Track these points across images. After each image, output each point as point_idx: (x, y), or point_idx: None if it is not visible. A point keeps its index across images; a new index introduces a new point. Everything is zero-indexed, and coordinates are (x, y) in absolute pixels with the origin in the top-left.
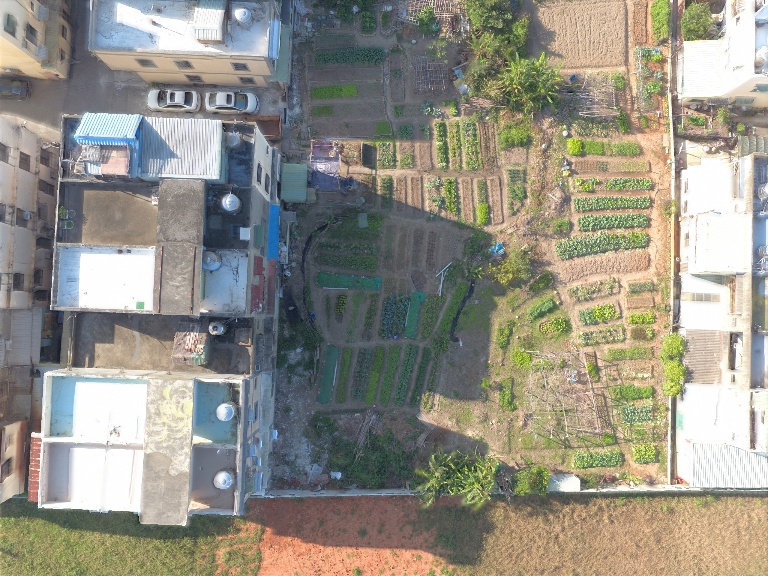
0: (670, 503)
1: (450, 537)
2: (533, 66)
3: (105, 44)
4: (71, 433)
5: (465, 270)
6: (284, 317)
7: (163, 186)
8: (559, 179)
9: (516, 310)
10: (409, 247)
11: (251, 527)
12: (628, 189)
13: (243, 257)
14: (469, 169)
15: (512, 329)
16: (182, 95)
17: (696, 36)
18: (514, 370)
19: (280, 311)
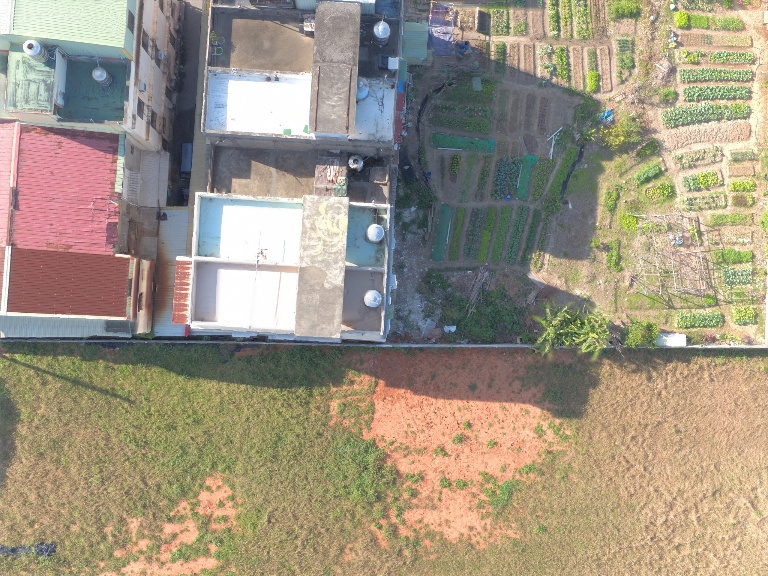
0: (767, 363)
1: (558, 392)
2: None
3: None
4: (218, 255)
5: (575, 135)
6: (399, 176)
7: (320, 8)
8: (666, 50)
9: (623, 175)
10: (521, 111)
11: (365, 379)
12: (731, 62)
13: (388, 89)
14: (580, 38)
15: (619, 193)
16: None
17: None
18: (621, 232)
19: None
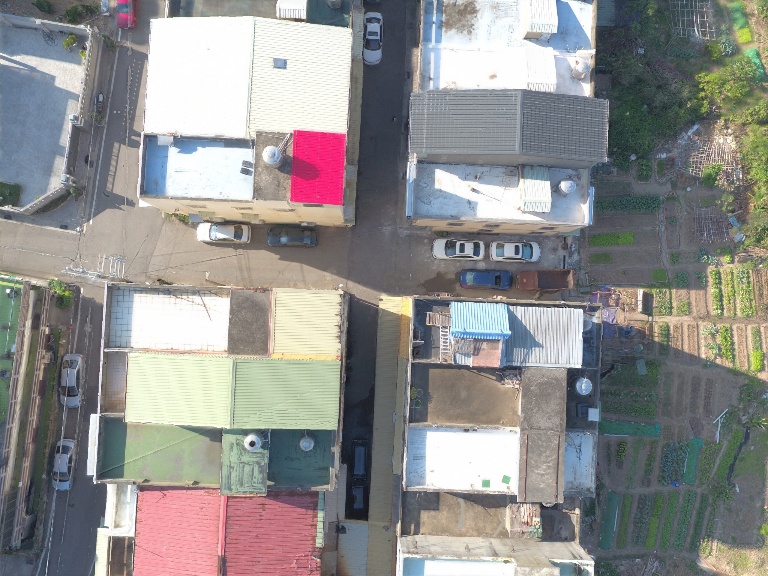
0: None
1: None
2: None
3: (424, 210)
4: None
5: (741, 417)
6: None
7: (526, 374)
8: None
9: None
10: (687, 394)
11: None
12: None
13: (586, 435)
14: (743, 316)
15: None
16: (471, 246)
17: None
18: None
19: None
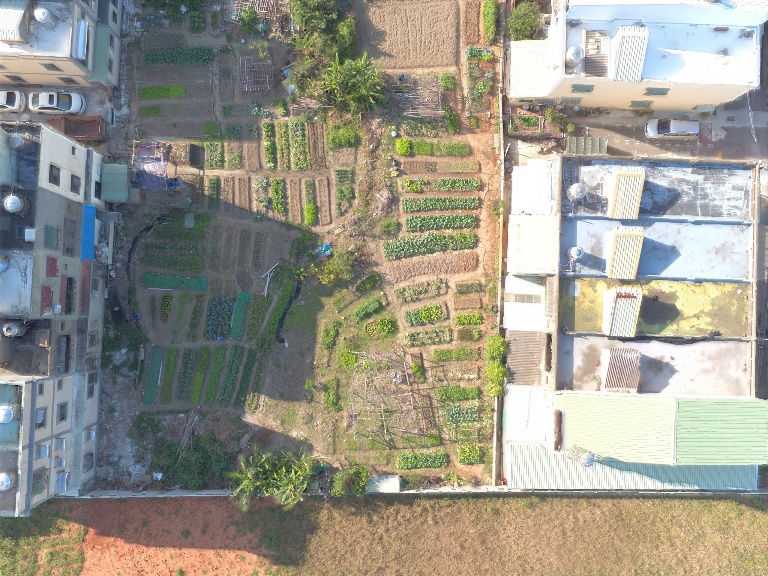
0: (495, 504)
1: (273, 538)
2: (354, 66)
3: None
4: None
5: None
6: (109, 318)
7: None
8: (387, 180)
9: (343, 311)
10: (235, 248)
11: (74, 527)
12: (457, 190)
13: (32, 259)
14: (297, 170)
15: (338, 330)
16: (4, 95)
17: (524, 36)
18: (339, 371)
19: (106, 312)
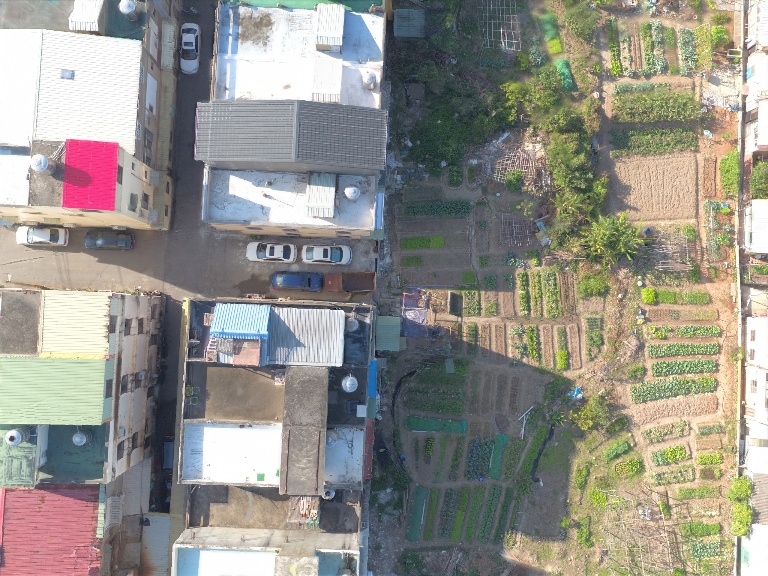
0: None
1: None
2: (614, 226)
3: (218, 214)
4: None
5: (546, 414)
6: (375, 458)
7: (289, 373)
8: (634, 327)
9: (593, 451)
10: (493, 392)
11: None
12: (698, 336)
13: (357, 431)
14: (549, 317)
15: (589, 469)
16: (281, 249)
17: (764, 194)
18: (591, 509)
19: None
